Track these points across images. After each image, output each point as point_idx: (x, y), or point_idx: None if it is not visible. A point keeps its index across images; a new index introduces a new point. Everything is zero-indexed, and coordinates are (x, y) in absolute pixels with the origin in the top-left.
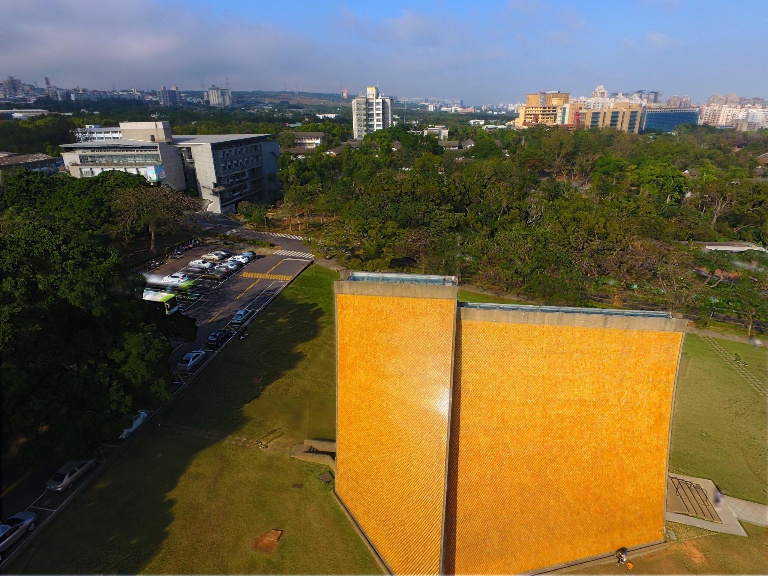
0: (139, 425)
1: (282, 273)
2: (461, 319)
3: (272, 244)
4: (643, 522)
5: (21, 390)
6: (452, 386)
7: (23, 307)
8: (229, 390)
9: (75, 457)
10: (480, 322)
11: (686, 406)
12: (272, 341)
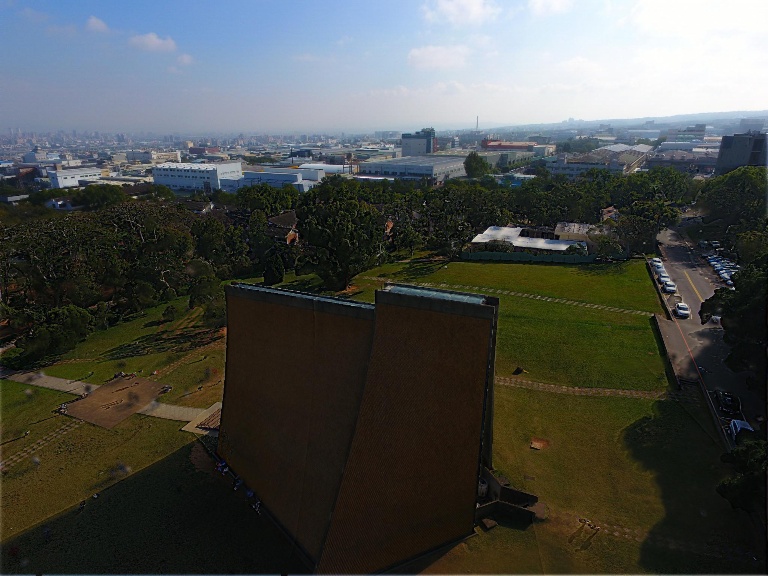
0: None
1: None
2: None
3: None
4: None
5: None
6: None
7: None
8: None
9: None
10: None
11: (47, 511)
12: None
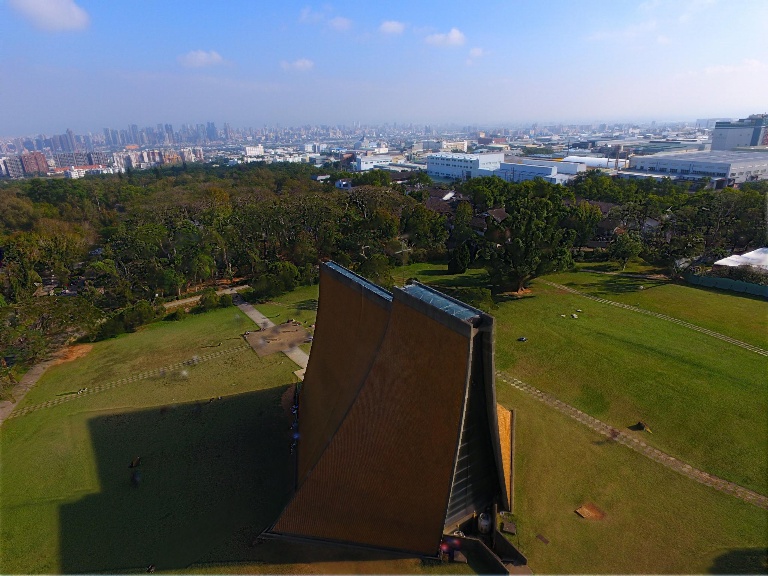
0: None
1: None
2: None
3: None
4: None
5: None
6: None
7: None
8: None
9: None
10: None
11: (194, 396)
12: None
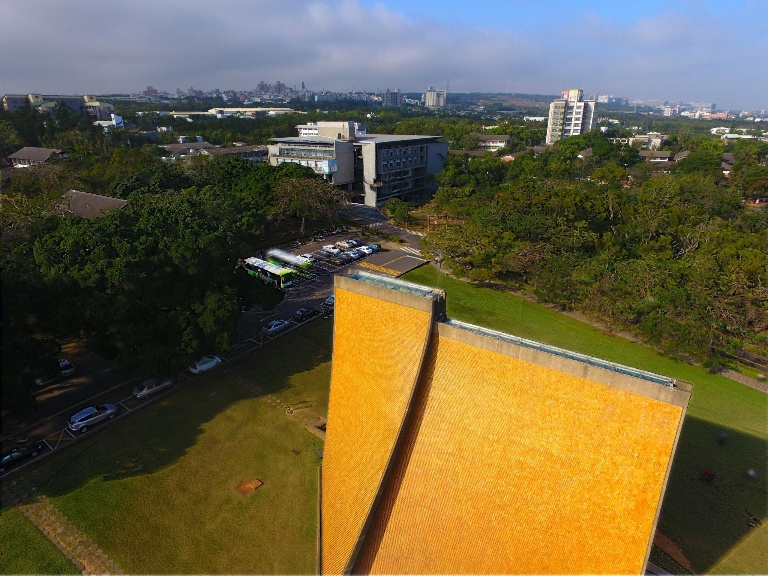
0: (212, 367)
1: (394, 268)
2: (439, 334)
3: (403, 240)
4: None
5: (123, 317)
6: (411, 398)
7: (140, 258)
8: (290, 358)
9: (147, 375)
10: (456, 341)
11: None
12: None
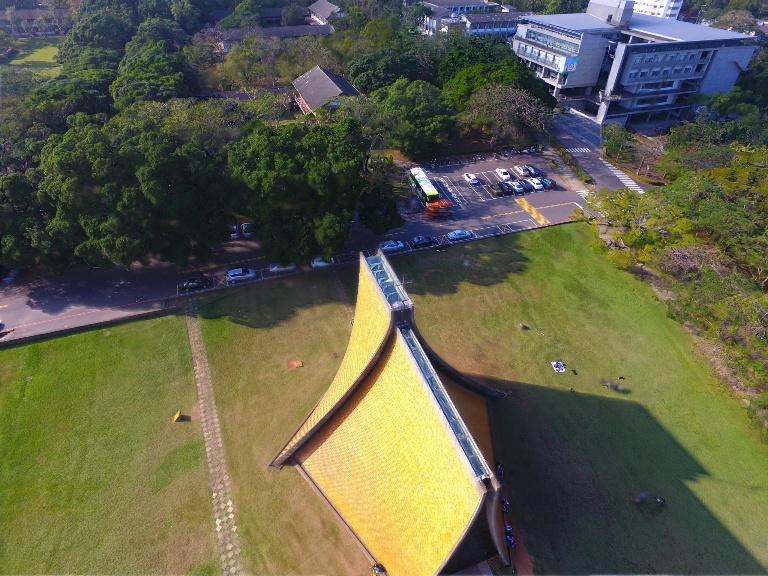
0: (326, 265)
1: (548, 215)
2: (397, 336)
3: (592, 180)
4: (405, 575)
5: (265, 216)
6: (364, 370)
7: (287, 175)
8: None
9: (272, 261)
10: (402, 348)
11: None
12: (451, 266)
